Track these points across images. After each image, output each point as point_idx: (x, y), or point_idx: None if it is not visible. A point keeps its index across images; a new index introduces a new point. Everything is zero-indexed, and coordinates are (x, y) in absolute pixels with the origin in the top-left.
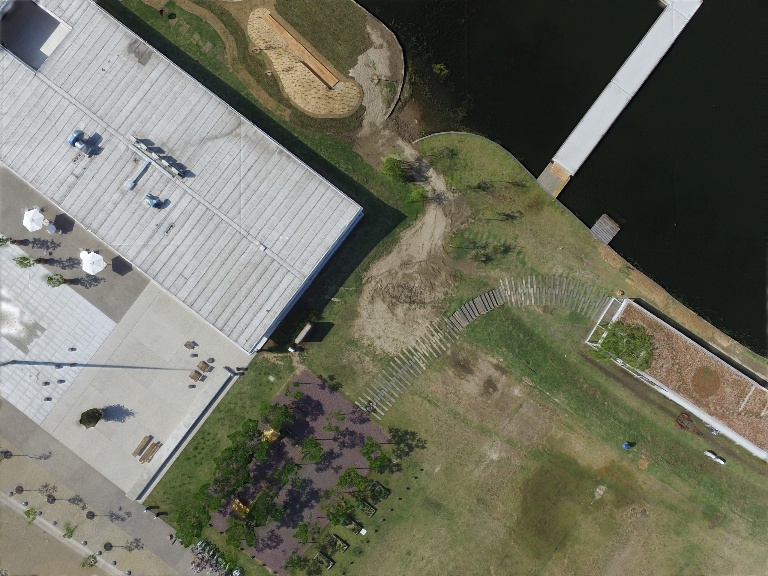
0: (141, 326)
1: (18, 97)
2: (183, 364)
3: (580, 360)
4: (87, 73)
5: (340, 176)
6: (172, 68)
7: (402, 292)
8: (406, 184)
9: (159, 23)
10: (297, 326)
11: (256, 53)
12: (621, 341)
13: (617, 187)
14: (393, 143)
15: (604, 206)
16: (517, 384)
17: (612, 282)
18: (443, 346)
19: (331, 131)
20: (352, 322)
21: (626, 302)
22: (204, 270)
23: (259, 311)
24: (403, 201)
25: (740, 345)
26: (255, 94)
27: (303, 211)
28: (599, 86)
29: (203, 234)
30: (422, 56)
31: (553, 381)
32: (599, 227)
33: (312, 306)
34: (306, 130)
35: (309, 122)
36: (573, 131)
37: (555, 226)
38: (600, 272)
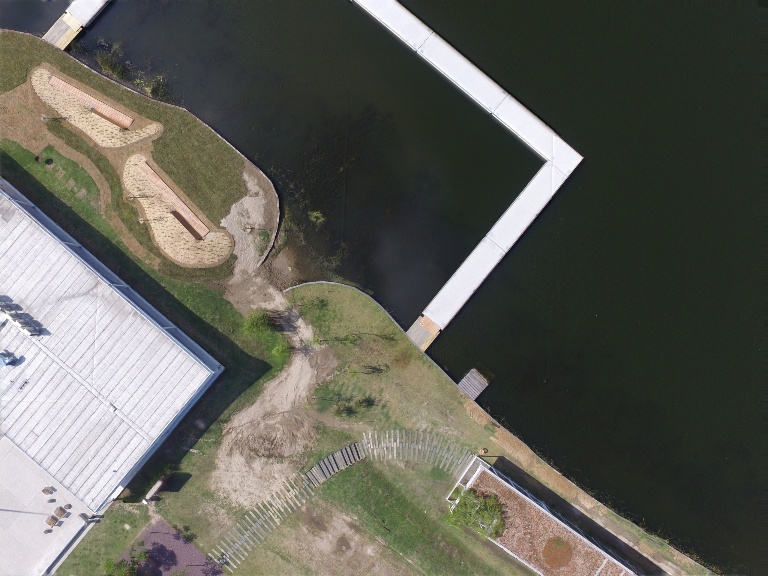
0: (2, 469)
1: None
2: (41, 508)
3: (440, 516)
4: None
5: (204, 328)
6: (34, 226)
7: (262, 444)
8: (274, 333)
9: (36, 168)
10: (151, 479)
11: (130, 200)
12: (470, 511)
13: (488, 341)
14: (264, 291)
15: (474, 360)
16: (370, 543)
17: (476, 439)
18: (298, 502)
19: (200, 280)
20: (209, 474)
21: (480, 469)
22: (55, 428)
23: (106, 471)
24: (270, 351)
25: (604, 507)
26: (126, 242)
27: (154, 373)
28: (475, 239)
29: (56, 392)
30: (299, 203)
31: (408, 540)
32: (467, 382)
33: (170, 457)
34: (175, 279)
35: (178, 271)
36: (445, 285)
37: (421, 381)
38: (464, 429)
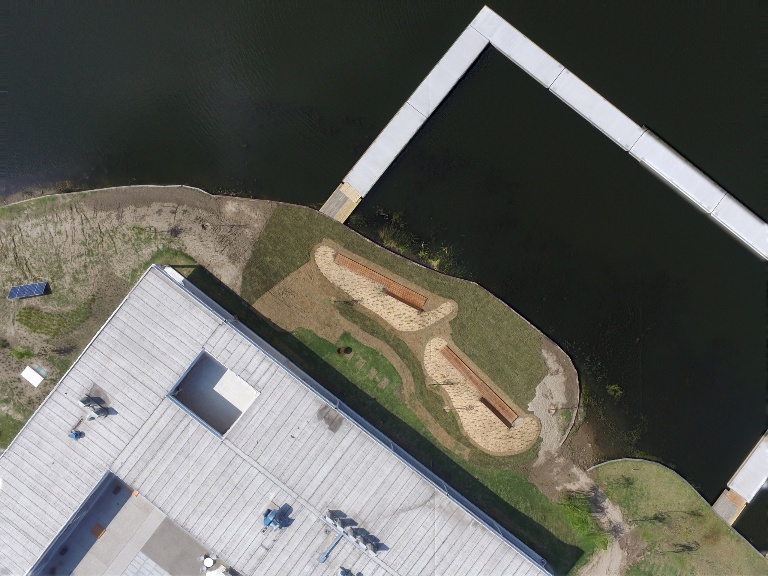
0: None
1: (205, 465)
2: None
3: None
4: (276, 440)
5: (521, 520)
6: (364, 436)
7: None
8: None
9: (334, 358)
10: None
11: (433, 388)
12: None
13: None
14: (568, 471)
15: None
16: None
17: None
18: None
19: (509, 466)
20: None
21: None
22: None
23: None
24: (579, 534)
25: None
26: (433, 432)
27: None
28: None
29: None
30: (596, 377)
31: None
32: None
33: None
34: (485, 468)
35: (488, 460)
36: (749, 457)
37: (731, 556)
38: None
